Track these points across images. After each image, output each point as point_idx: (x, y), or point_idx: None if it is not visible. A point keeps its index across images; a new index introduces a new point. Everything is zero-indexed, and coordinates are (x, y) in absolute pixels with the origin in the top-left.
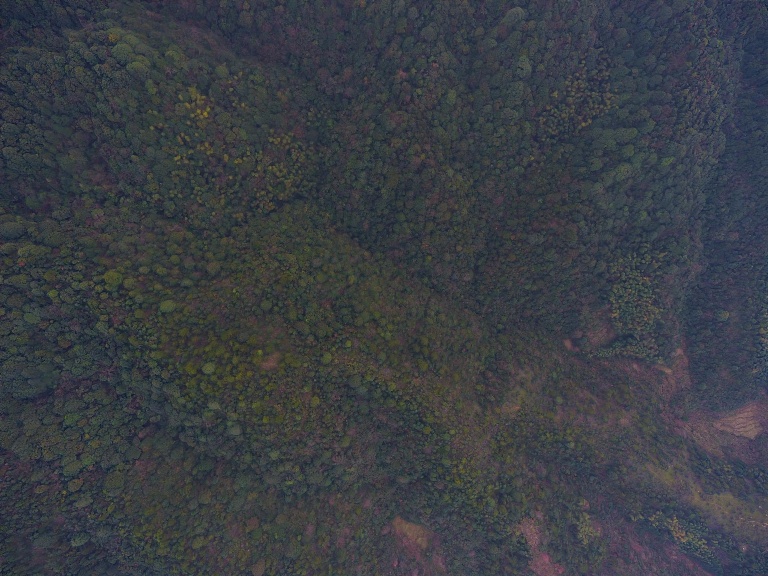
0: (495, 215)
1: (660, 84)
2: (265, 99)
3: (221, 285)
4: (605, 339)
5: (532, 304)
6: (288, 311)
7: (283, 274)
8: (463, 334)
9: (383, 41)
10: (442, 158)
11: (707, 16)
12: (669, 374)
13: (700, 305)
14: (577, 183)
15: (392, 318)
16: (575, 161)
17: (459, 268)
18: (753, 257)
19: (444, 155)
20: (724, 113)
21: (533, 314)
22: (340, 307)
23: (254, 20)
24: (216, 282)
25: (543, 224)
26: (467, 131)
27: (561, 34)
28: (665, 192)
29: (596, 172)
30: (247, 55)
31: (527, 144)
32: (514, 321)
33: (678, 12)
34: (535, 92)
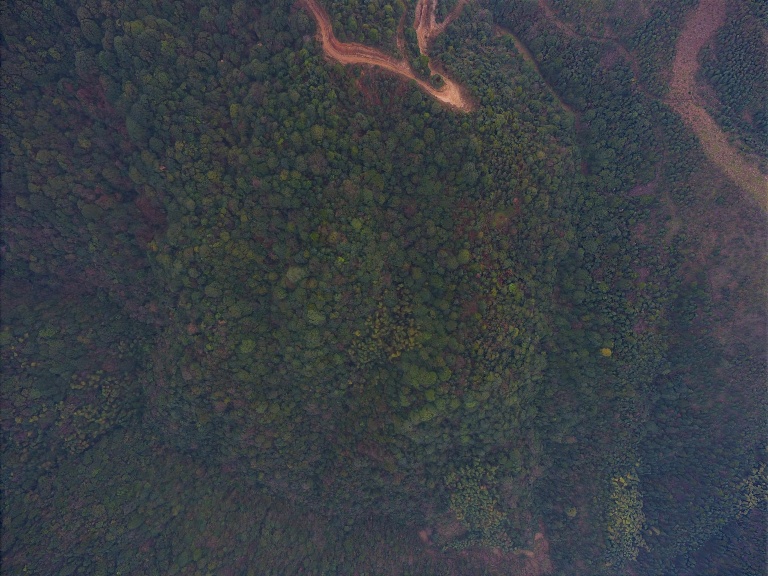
0: (327, 427)
1: (456, 330)
2: (62, 348)
3: (11, 564)
4: (459, 531)
5: (378, 505)
6: (95, 569)
7: (86, 533)
8: (301, 551)
9: (174, 290)
10: (250, 396)
11: (499, 260)
12: (531, 557)
13: (551, 497)
14: (390, 416)
15: (216, 553)
16: (388, 393)
17: (296, 479)
18: (594, 457)
19: (255, 389)
20: (535, 341)
21: (383, 511)
22: (160, 547)
23: (46, 267)
24: (7, 559)
25: (366, 448)
26: (279, 362)
27: (347, 288)
28: (480, 422)
29: (407, 407)
30: (49, 293)
31: (342, 371)
32: (364, 519)
33: (464, 263)
34: (336, 332)
